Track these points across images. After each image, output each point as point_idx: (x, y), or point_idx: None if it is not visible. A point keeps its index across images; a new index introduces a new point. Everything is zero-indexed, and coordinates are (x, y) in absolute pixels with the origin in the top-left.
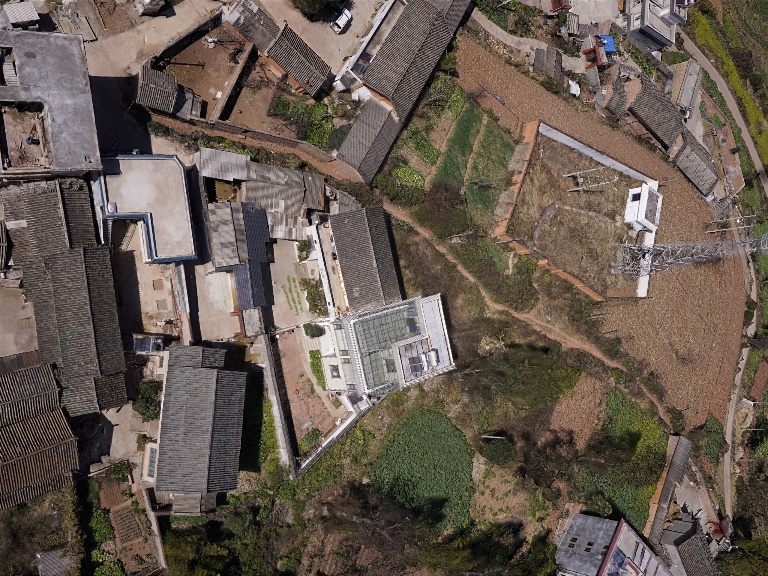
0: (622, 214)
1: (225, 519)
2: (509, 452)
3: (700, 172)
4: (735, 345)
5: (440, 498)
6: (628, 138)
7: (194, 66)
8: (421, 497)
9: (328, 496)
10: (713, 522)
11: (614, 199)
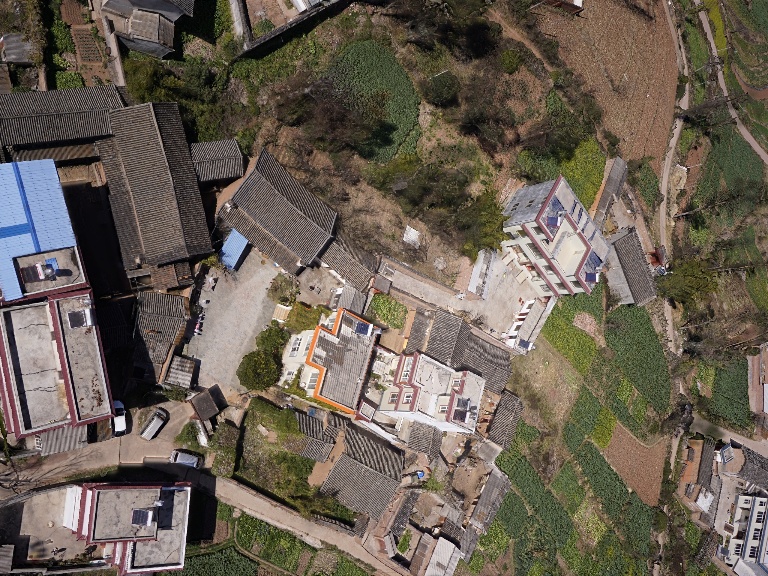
0: None
1: (182, 74)
2: (452, 82)
3: None
4: (668, 112)
5: (388, 125)
6: None
7: None
8: (370, 117)
9: (281, 88)
10: (649, 252)
11: None
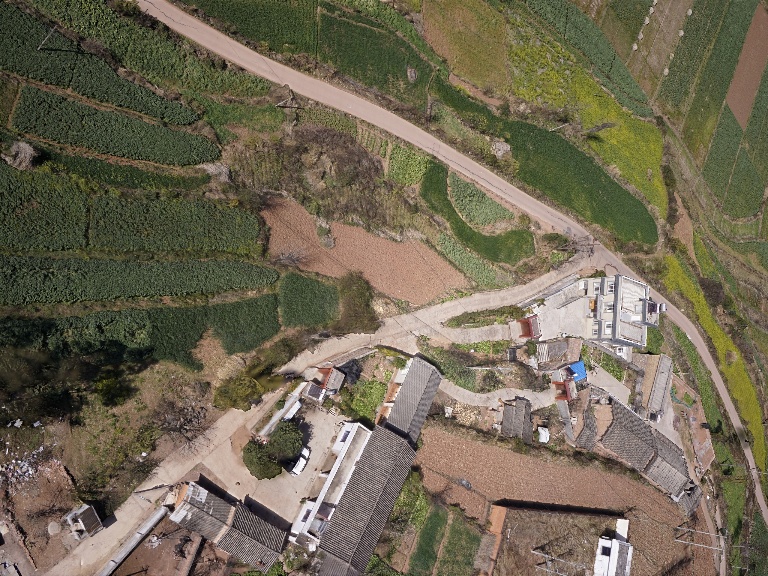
0: (591, 567)
1: None
2: None
3: (671, 477)
4: None
5: None
6: (598, 470)
7: (136, 574)
8: None
9: None
10: None
11: (583, 557)
